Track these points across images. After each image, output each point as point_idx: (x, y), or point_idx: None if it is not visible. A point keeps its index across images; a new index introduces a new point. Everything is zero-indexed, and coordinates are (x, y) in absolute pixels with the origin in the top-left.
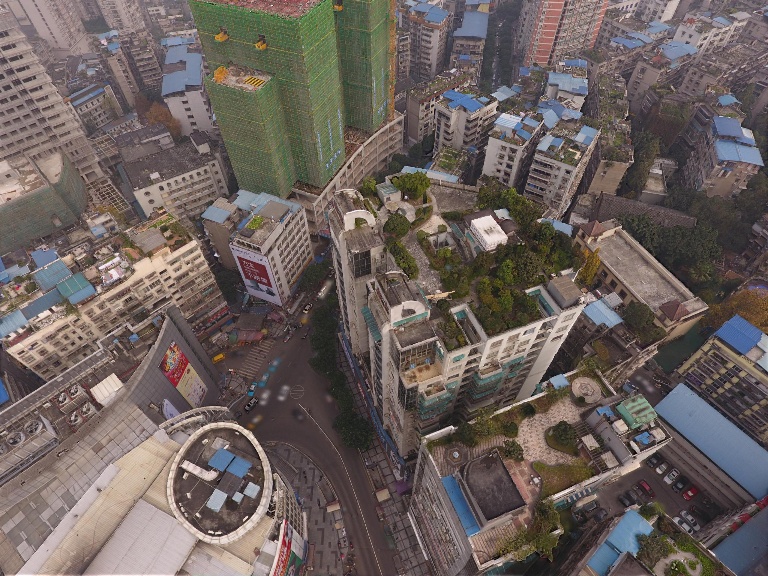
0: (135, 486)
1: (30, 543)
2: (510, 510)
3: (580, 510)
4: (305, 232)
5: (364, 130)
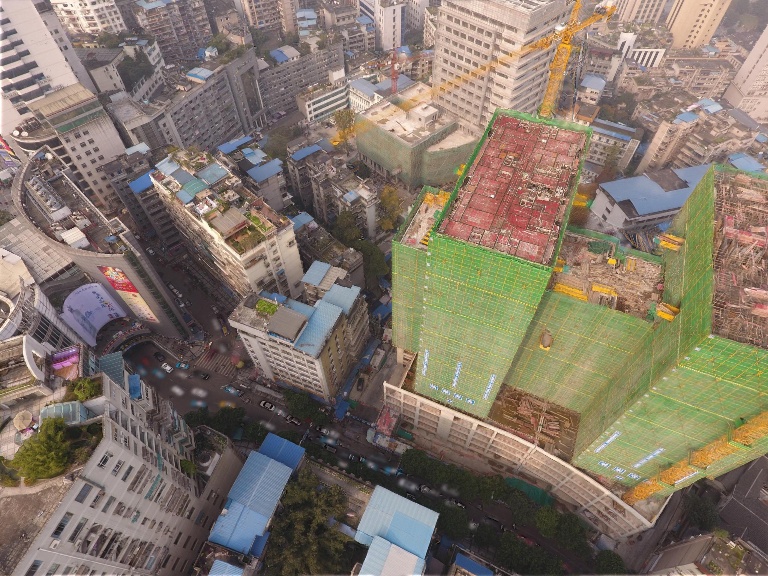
0: None
1: None
2: None
3: None
4: None
5: None
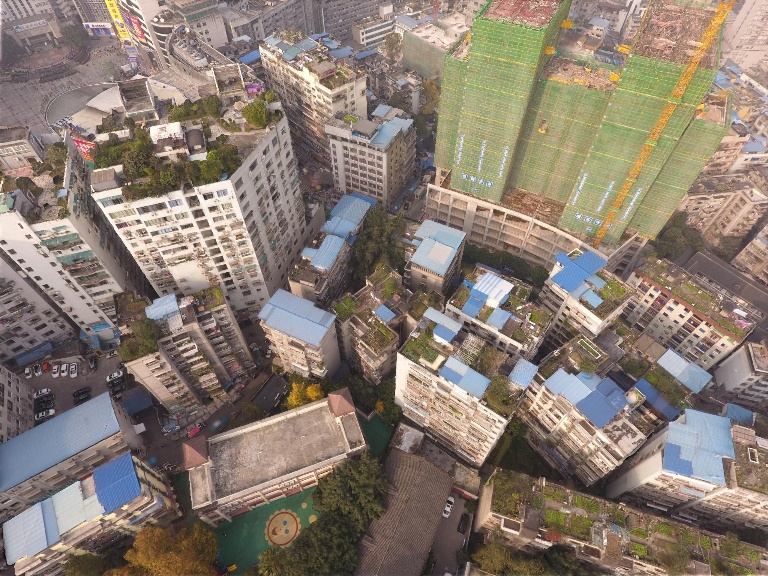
0: (161, 97)
1: (153, 77)
2: None
3: (92, 352)
4: (383, 175)
5: None
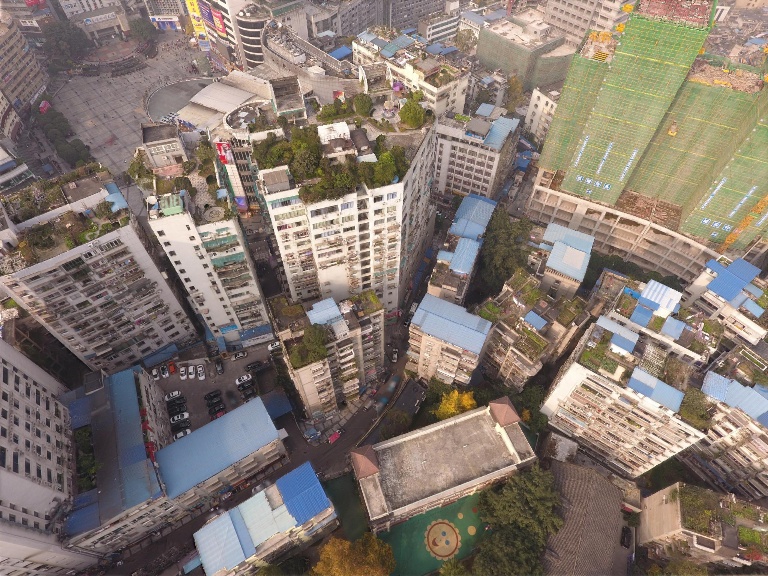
0: (264, 94)
1: (250, 73)
2: (144, 137)
3: (217, 354)
4: (490, 175)
5: None
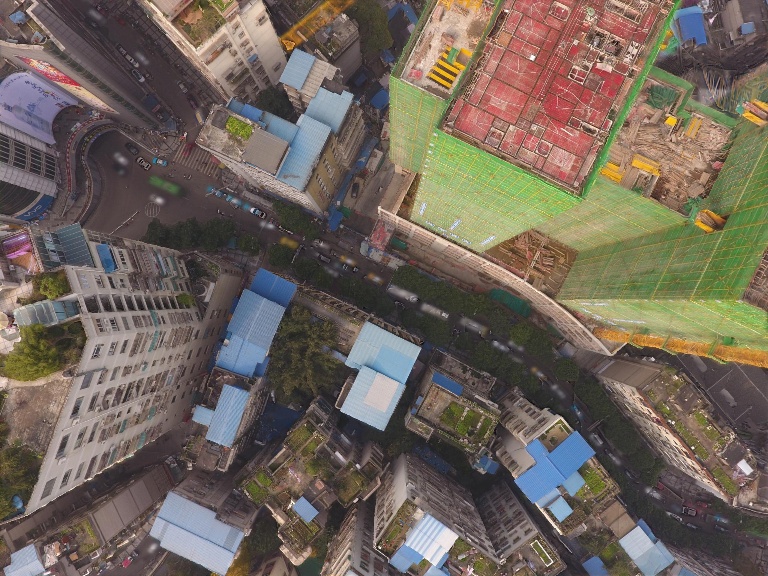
0: None
1: None
2: None
3: None
4: None
5: (563, 283)
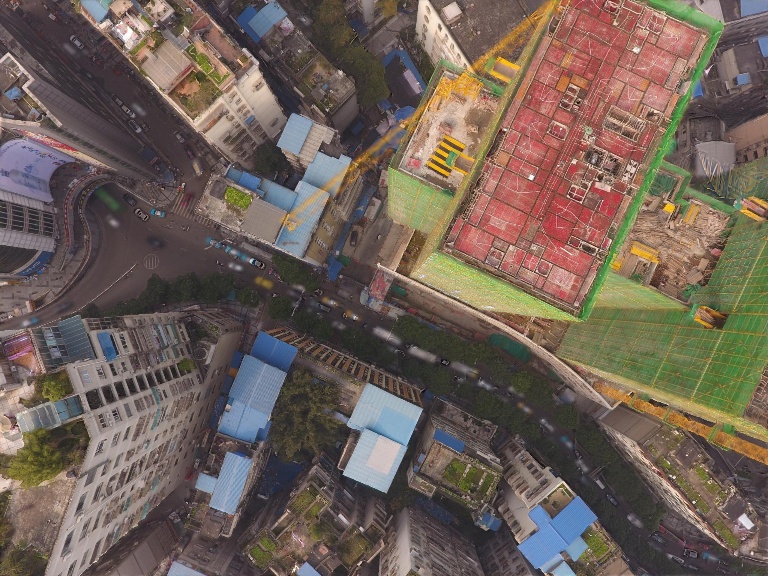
0: None
1: None
2: None
3: None
4: None
5: (563, 338)
